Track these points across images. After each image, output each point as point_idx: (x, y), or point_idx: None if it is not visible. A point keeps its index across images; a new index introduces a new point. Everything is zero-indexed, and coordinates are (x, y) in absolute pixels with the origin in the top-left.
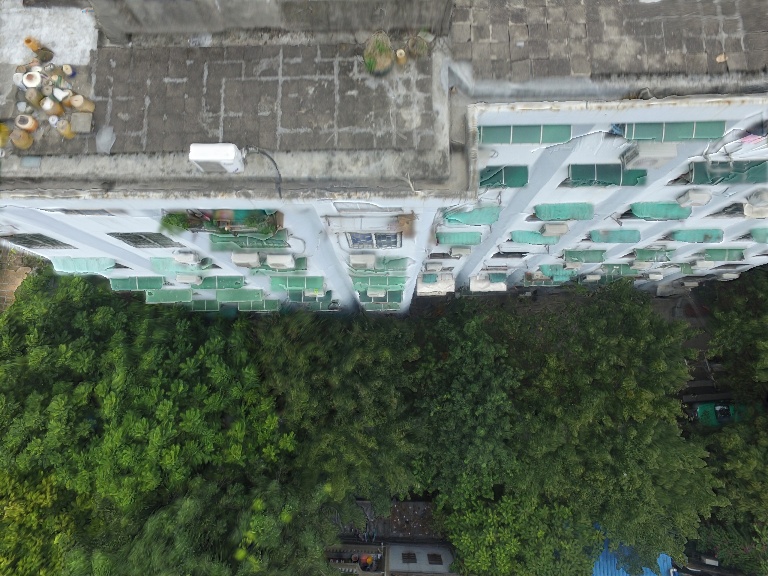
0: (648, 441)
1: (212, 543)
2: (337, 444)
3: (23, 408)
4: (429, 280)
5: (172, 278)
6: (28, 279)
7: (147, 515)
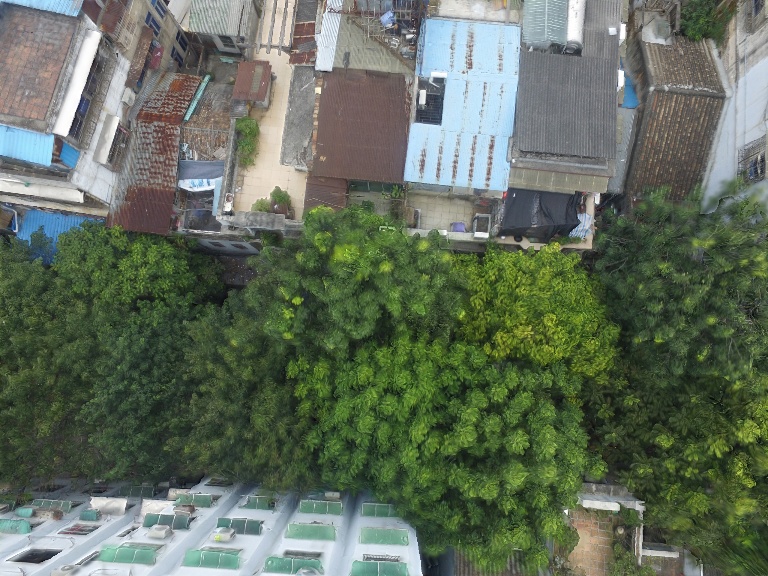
0: None
1: (325, 303)
2: (241, 368)
3: (504, 434)
4: None
5: (347, 571)
6: (544, 563)
7: None
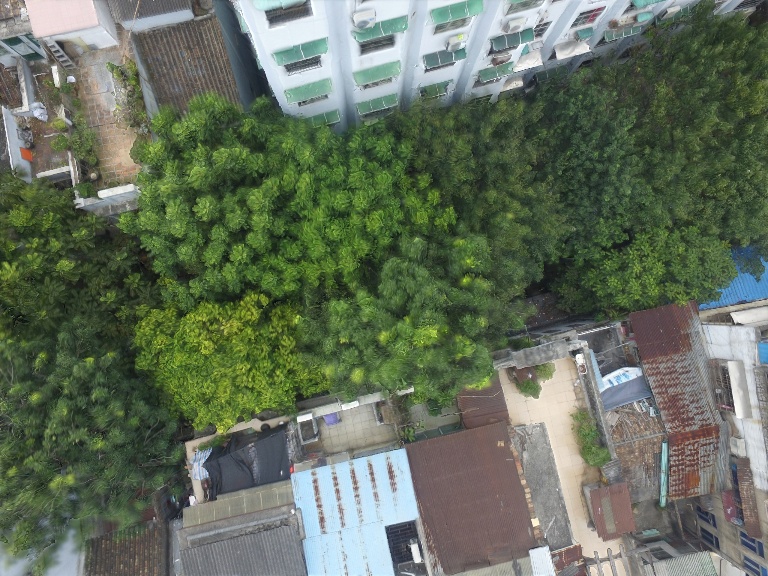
0: (767, 130)
1: None
2: (500, 201)
3: (221, 214)
4: (522, 52)
5: (331, 44)
6: (155, 119)
7: (362, 291)
